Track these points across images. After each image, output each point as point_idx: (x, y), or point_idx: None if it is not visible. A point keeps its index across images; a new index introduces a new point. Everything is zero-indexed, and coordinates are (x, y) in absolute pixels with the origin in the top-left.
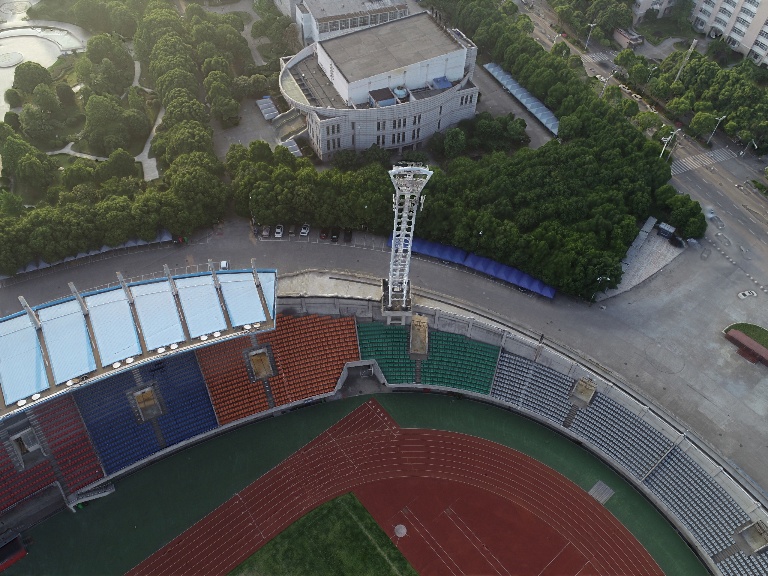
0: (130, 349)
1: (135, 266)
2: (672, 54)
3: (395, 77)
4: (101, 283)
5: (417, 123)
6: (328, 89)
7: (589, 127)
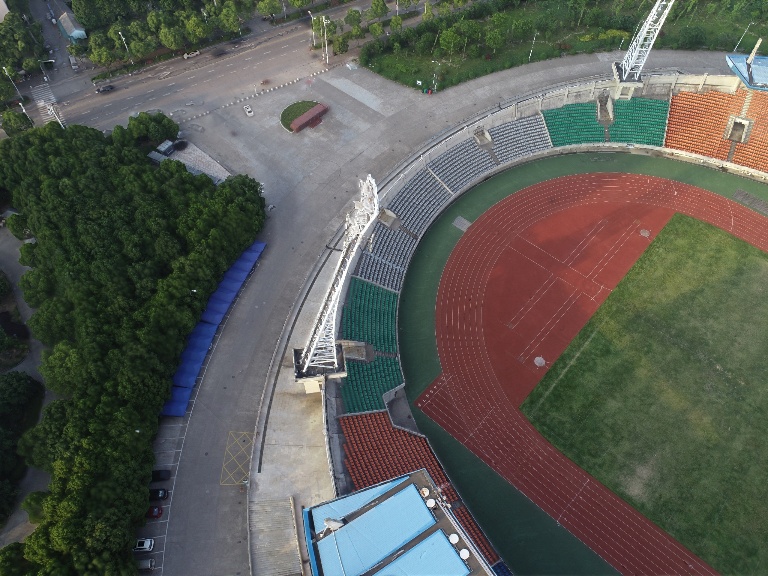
0: None
1: None
2: None
3: None
4: None
5: None
6: None
7: None
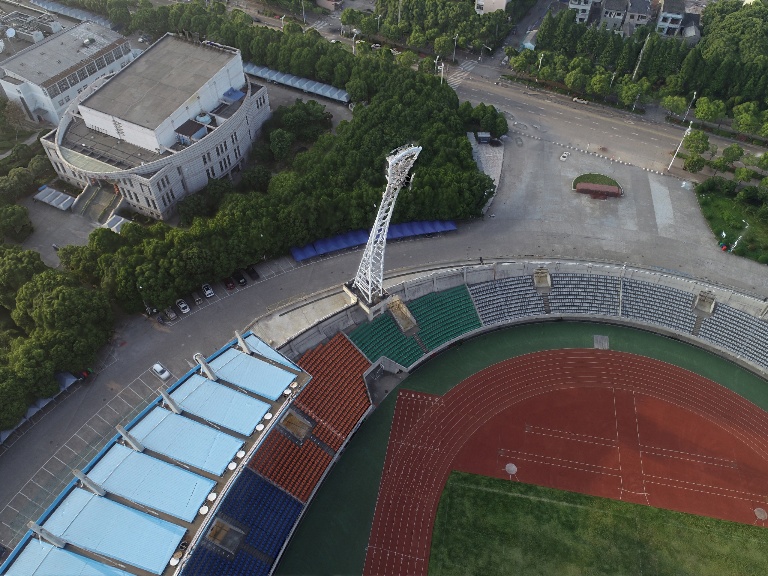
0: (199, 488)
1: (56, 430)
2: (379, 1)
3: (192, 106)
4: (32, 472)
5: (235, 141)
6: (124, 147)
7: (373, 83)
